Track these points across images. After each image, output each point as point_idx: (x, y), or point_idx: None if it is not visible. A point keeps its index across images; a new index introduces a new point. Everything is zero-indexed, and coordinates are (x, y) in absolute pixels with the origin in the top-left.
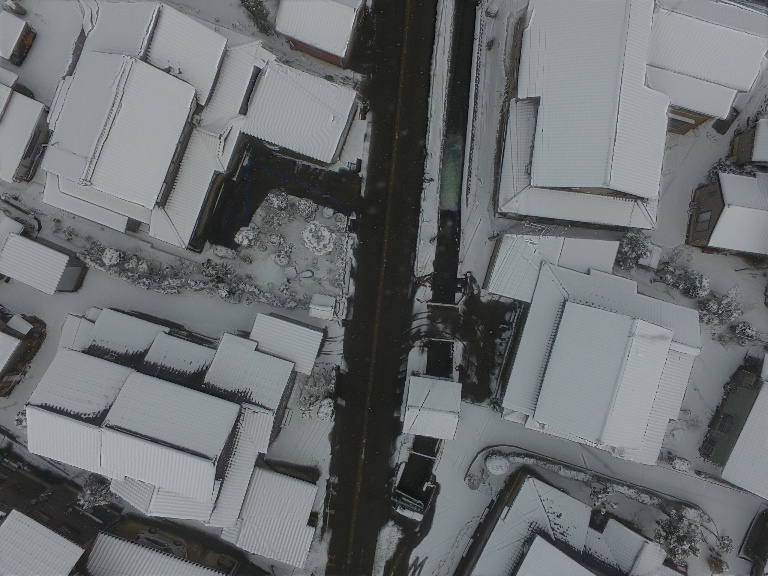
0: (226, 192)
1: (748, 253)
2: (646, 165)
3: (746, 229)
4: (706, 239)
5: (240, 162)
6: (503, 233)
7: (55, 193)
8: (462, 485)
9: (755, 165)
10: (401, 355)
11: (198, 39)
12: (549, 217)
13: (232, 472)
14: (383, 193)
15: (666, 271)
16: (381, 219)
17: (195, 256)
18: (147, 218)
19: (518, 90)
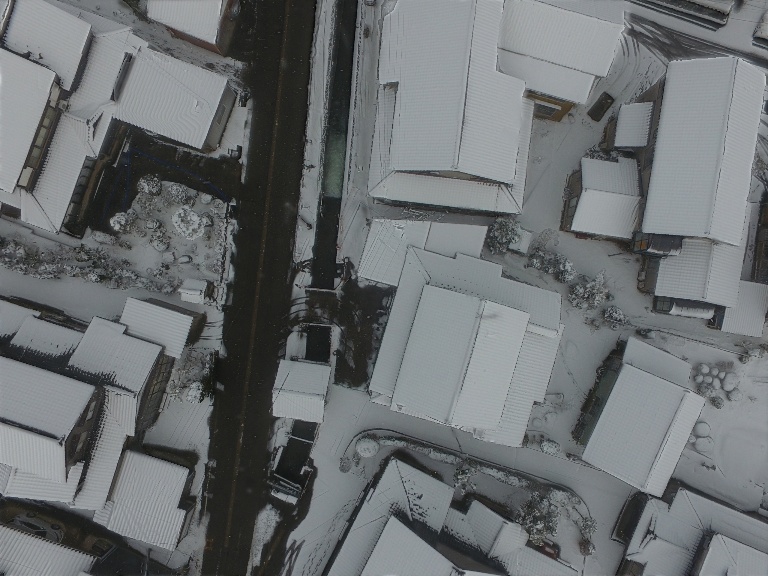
0: (107, 178)
1: None
2: (500, 149)
3: (605, 213)
4: None
5: (120, 149)
6: None
7: None
8: None
9: (621, 151)
10: (280, 340)
11: (59, 25)
12: (417, 202)
13: (98, 454)
14: (263, 179)
15: (537, 256)
16: (261, 205)
17: (76, 242)
18: (19, 203)
19: (379, 75)
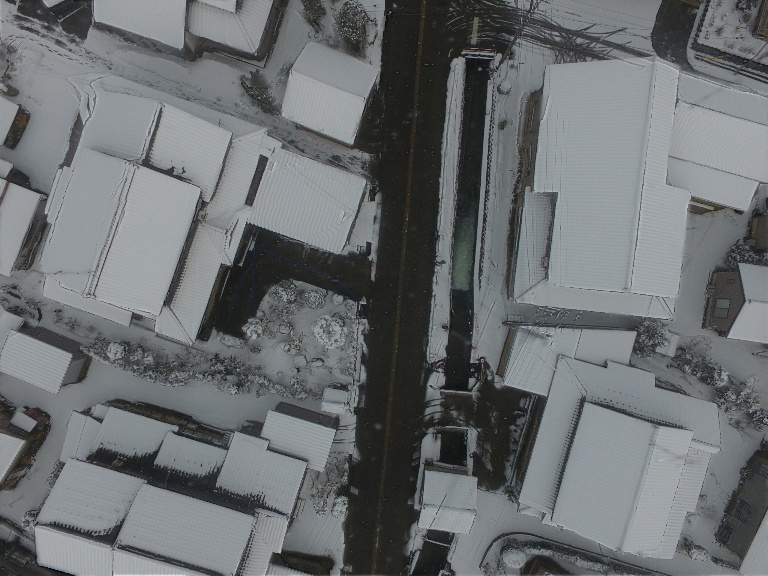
0: (232, 278)
1: None
2: (667, 264)
3: (767, 323)
4: (724, 327)
5: (246, 247)
6: (517, 318)
7: (56, 288)
8: (477, 573)
9: None
10: (414, 442)
11: (202, 136)
12: (565, 308)
13: (246, 574)
14: (394, 277)
15: (683, 358)
16: (392, 304)
17: (202, 344)
18: None
19: (535, 184)
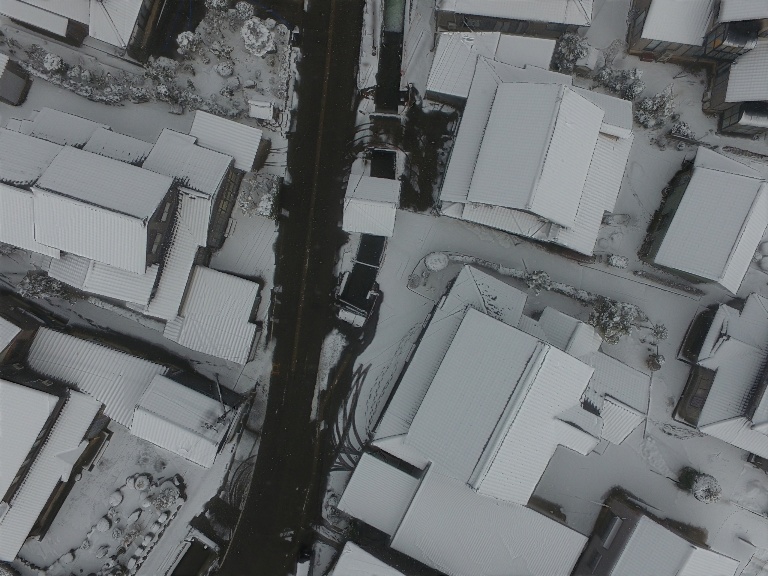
0: (169, 7)
1: (684, 57)
2: None
3: (677, 16)
4: None
5: None
6: None
7: None
8: (405, 292)
9: None
10: (344, 166)
11: None
12: (486, 15)
13: (171, 262)
14: (326, 7)
15: None
16: (324, 33)
17: (139, 70)
18: (86, 17)
19: None
